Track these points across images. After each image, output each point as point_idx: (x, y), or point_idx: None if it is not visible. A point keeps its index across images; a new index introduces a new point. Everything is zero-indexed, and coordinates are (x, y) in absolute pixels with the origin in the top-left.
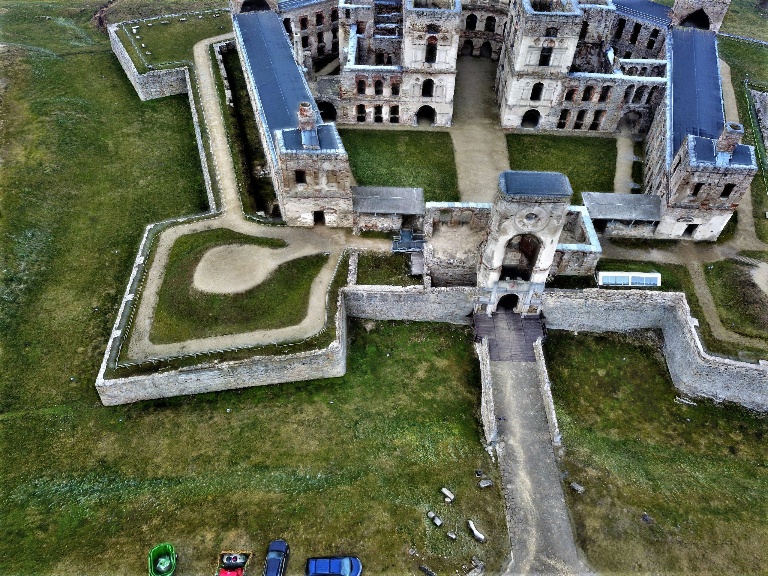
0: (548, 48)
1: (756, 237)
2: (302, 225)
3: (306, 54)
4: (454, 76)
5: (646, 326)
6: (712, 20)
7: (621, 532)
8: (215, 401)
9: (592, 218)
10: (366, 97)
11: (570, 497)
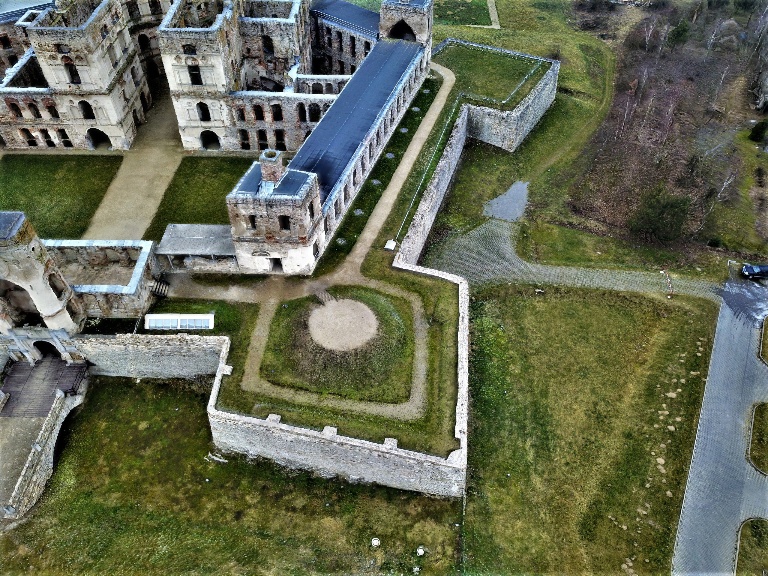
0: (194, 66)
1: (358, 270)
2: None
3: None
4: (108, 97)
5: (211, 372)
6: (416, 31)
7: None
8: None
9: (161, 254)
10: (26, 121)
11: None
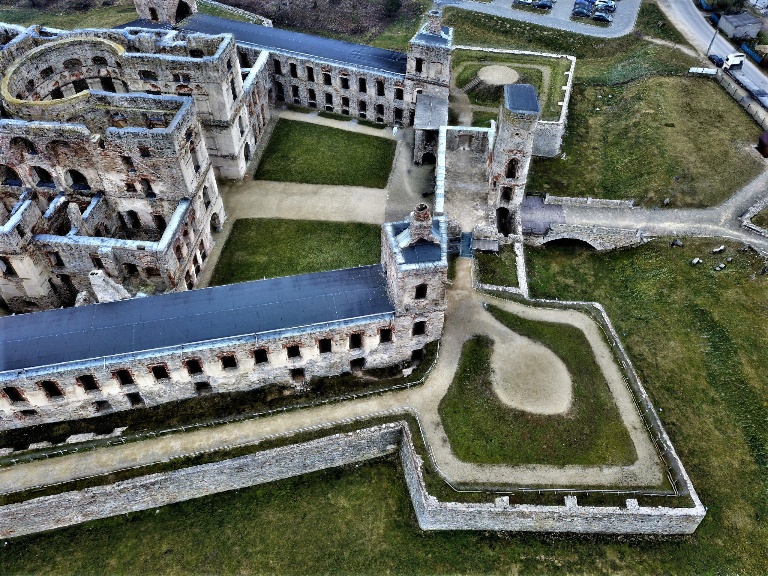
0: (231, 82)
1: None
2: None
3: (85, 297)
4: (211, 166)
5: None
6: (190, 4)
7: (691, 189)
8: None
9: None
10: (185, 260)
11: (673, 207)
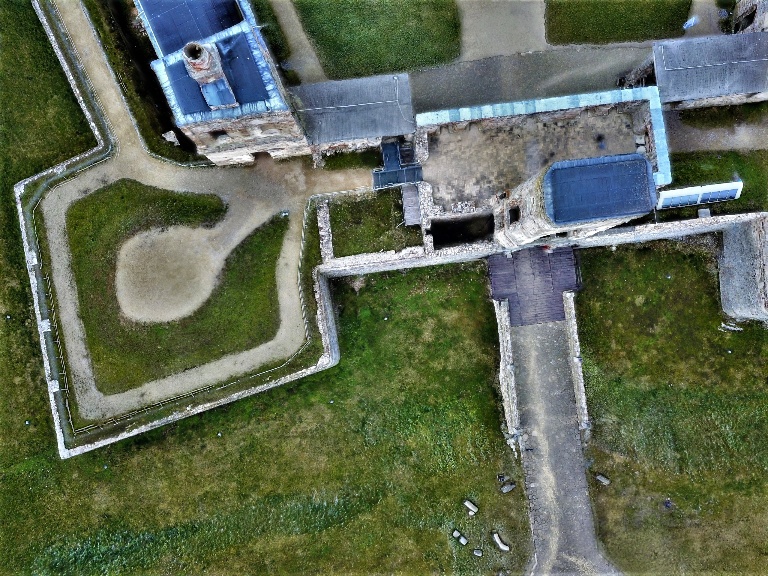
0: None
1: None
2: (237, 162)
3: None
4: None
5: (704, 232)
6: None
7: (642, 523)
8: (201, 425)
9: (663, 101)
10: None
11: (595, 489)
